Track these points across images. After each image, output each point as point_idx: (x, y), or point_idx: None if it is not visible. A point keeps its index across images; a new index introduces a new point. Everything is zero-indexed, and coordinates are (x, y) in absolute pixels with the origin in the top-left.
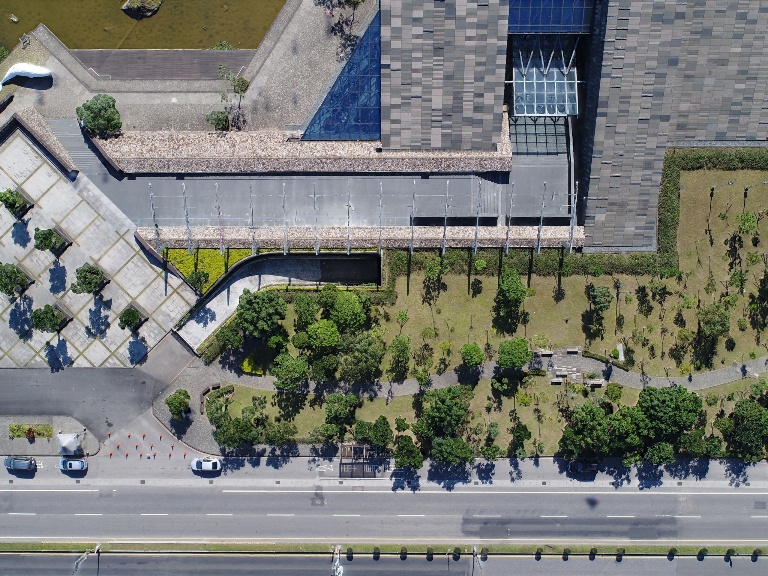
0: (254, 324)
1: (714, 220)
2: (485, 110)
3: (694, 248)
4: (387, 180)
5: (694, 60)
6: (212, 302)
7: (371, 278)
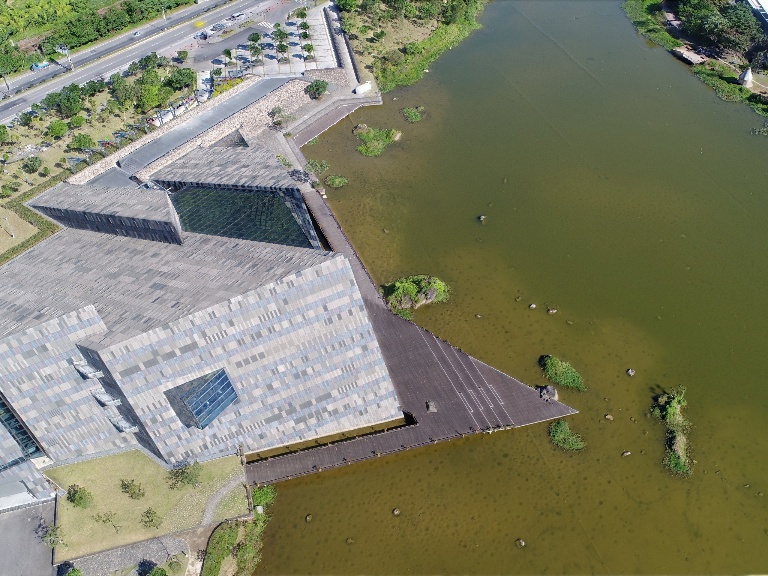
0: None
1: None
2: None
3: (2, 217)
4: None
5: None
6: None
7: None
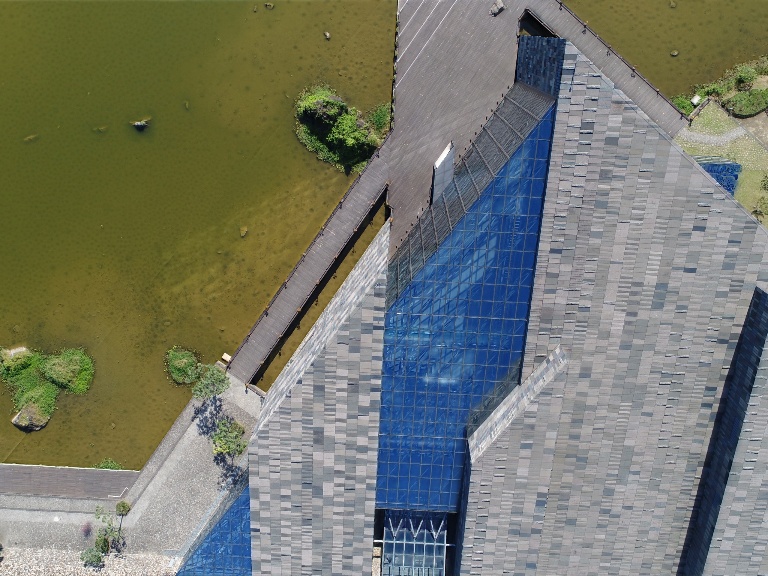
0: None
1: None
2: (354, 568)
3: None
4: None
5: (559, 542)
6: None
7: None
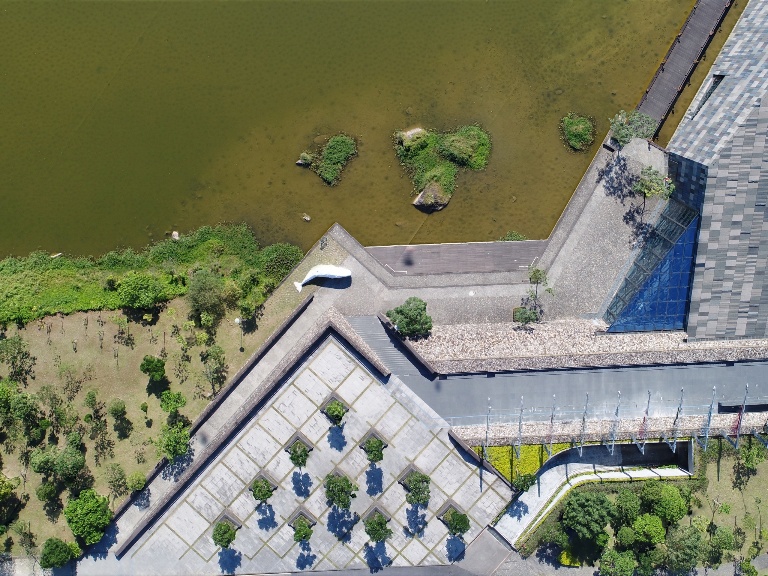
0: (587, 526)
1: None
2: None
3: None
4: (694, 369)
5: None
6: (524, 495)
7: (668, 458)
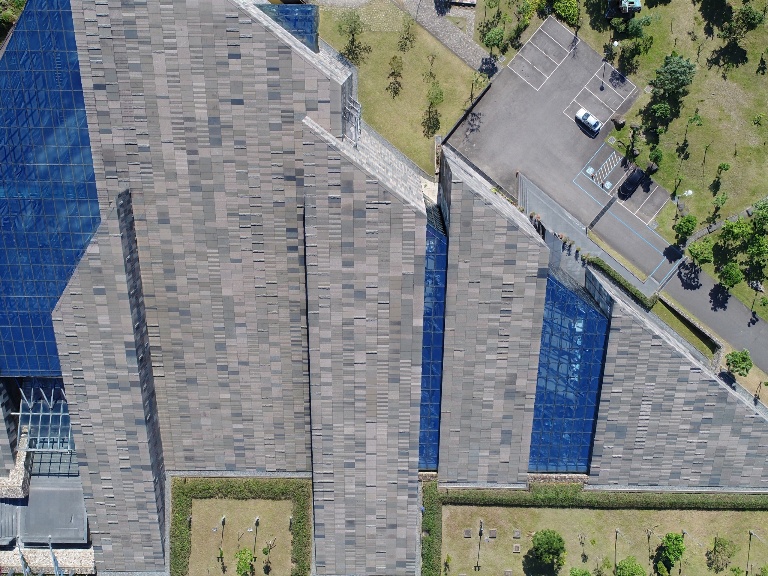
0: None
1: (226, 548)
2: None
3: (206, 575)
4: None
5: (186, 404)
6: None
7: None
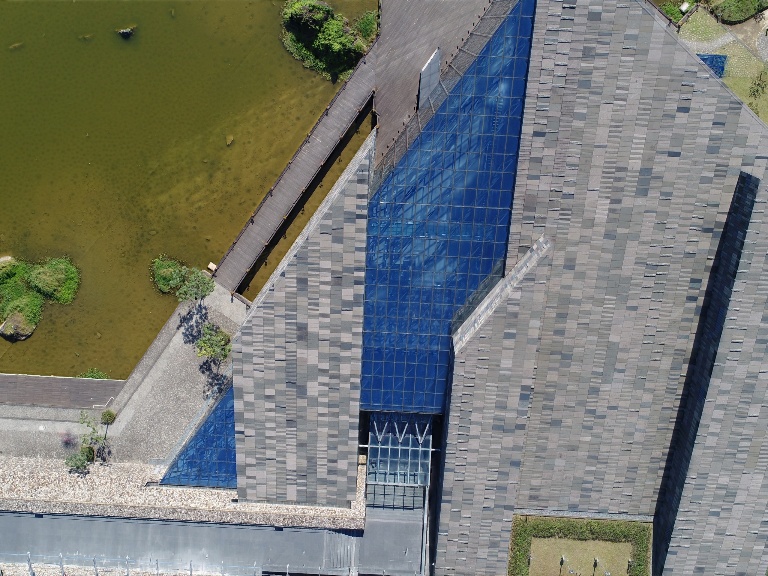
0: None
1: None
2: (339, 473)
3: None
4: (242, 530)
5: (544, 444)
6: None
7: None
